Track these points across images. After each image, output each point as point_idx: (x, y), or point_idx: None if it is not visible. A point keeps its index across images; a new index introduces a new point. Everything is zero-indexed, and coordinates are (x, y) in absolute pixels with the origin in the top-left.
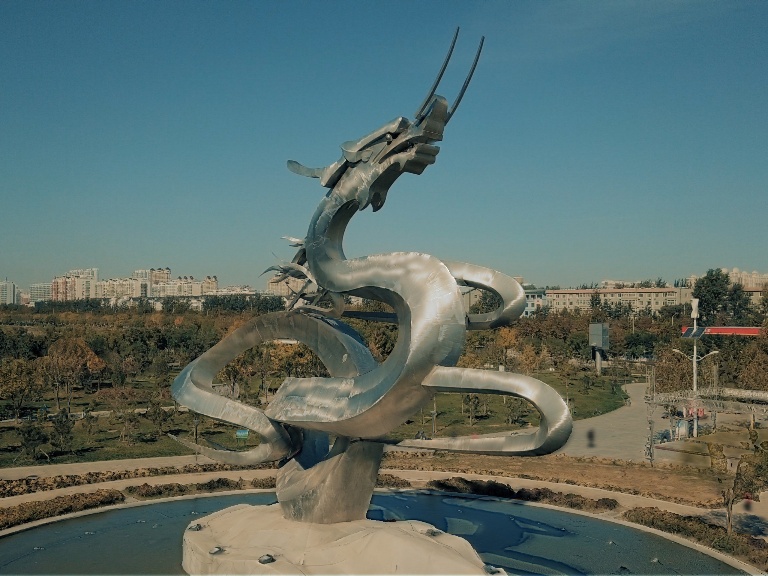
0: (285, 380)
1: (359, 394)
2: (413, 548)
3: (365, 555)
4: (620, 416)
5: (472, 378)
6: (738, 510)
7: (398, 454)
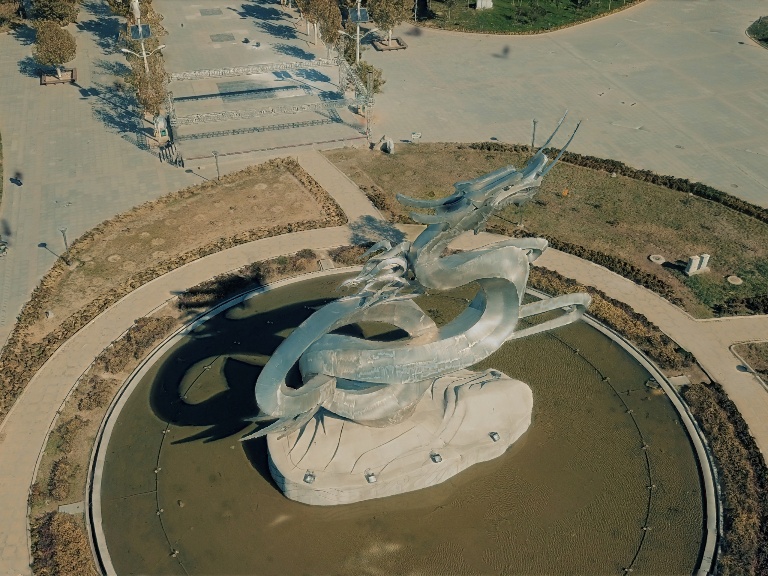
0: (379, 353)
1: (479, 343)
2: (496, 395)
3: (472, 415)
4: (6, 97)
5: (548, 305)
6: (353, 214)
7: (50, 283)
